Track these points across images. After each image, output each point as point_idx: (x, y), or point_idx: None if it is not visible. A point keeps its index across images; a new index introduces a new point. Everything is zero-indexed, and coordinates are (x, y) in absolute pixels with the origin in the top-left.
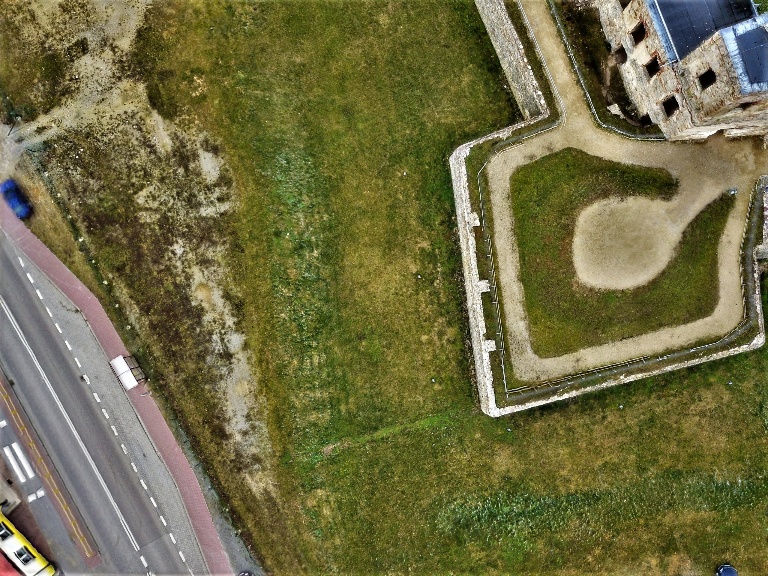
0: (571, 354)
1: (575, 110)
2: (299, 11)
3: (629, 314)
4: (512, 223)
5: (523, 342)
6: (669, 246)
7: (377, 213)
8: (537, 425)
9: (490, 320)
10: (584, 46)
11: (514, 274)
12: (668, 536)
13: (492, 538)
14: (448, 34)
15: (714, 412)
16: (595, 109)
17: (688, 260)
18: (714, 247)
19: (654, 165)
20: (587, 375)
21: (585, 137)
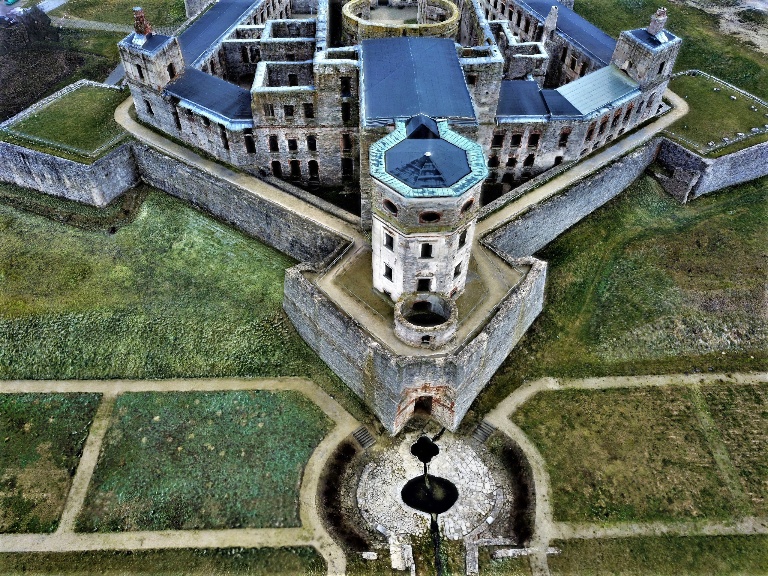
0: None
1: None
2: None
3: None
4: None
5: None
6: None
7: (596, 0)
8: None
9: None
10: None
11: None
12: None
13: None
14: None
15: None
16: None
17: None
18: None
19: None
20: None
21: None
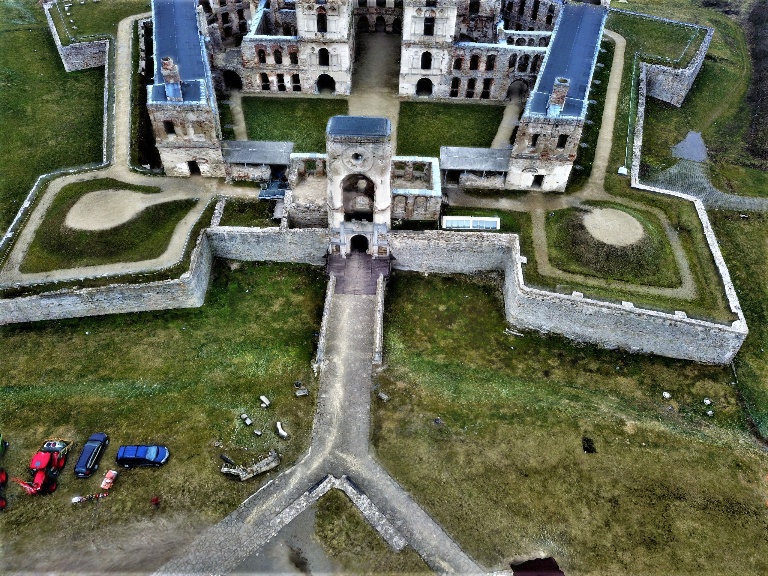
0: (45, 272)
1: (121, 164)
2: (2, 134)
3: (96, 250)
4: (49, 206)
5: (15, 264)
6: (133, 212)
7: None
8: (12, 338)
9: (1, 252)
10: (143, 142)
11: (33, 229)
12: (66, 412)
13: None
14: (86, 150)
15: (161, 344)
16: (134, 164)
17: (148, 224)
18: (174, 224)
19: (153, 185)
20: (49, 284)
21: (120, 174)
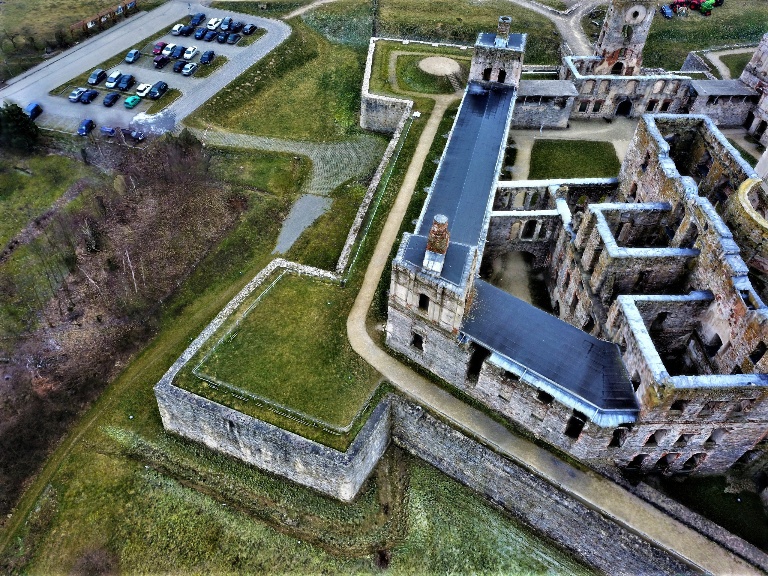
0: None
1: None
2: None
3: None
4: None
5: None
6: None
7: None
8: None
9: None
10: None
11: None
12: None
13: (764, 27)
14: None
15: None
16: None
17: None
18: None
19: None
20: None
21: None
